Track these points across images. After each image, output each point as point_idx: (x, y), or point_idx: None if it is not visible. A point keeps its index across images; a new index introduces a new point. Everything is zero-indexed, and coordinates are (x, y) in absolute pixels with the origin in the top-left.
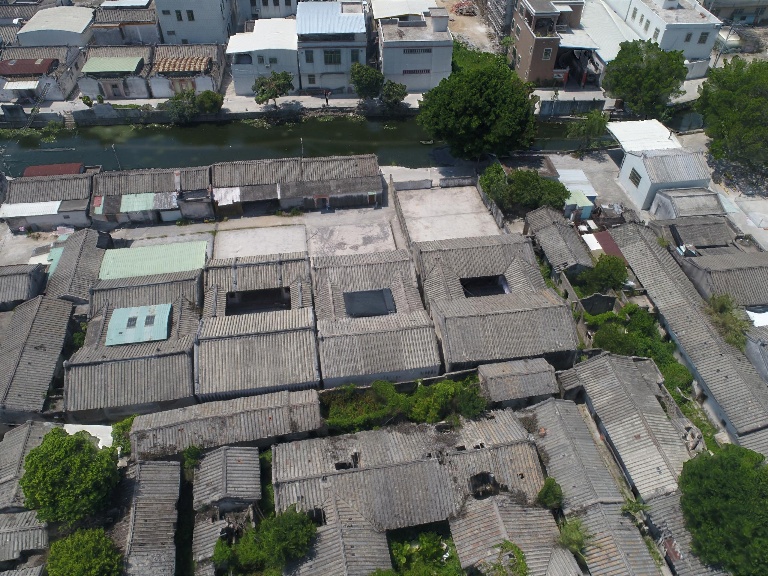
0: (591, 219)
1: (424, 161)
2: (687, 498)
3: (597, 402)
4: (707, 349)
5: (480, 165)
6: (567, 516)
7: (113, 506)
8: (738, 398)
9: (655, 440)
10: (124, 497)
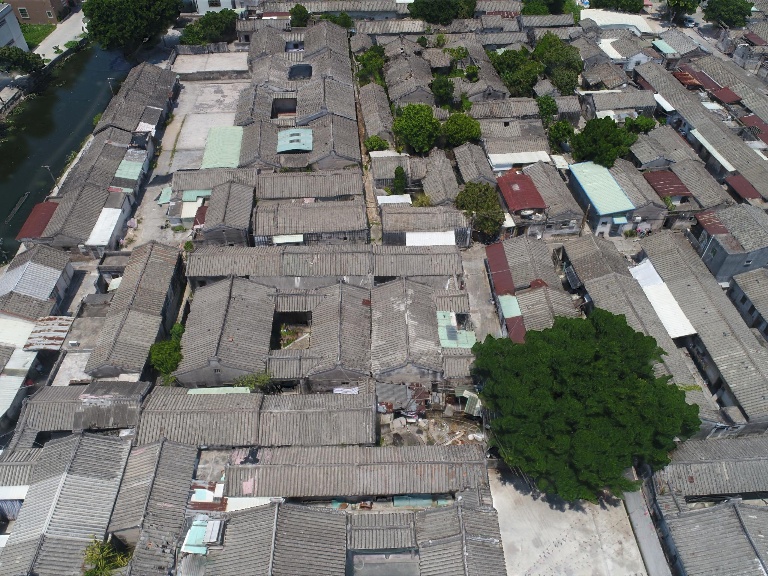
0: (248, 17)
1: (126, 74)
2: (431, 13)
3: (378, 31)
4: (356, 5)
5: (157, 48)
6: (429, 46)
7: None
8: (382, 5)
9: (402, 20)
10: None
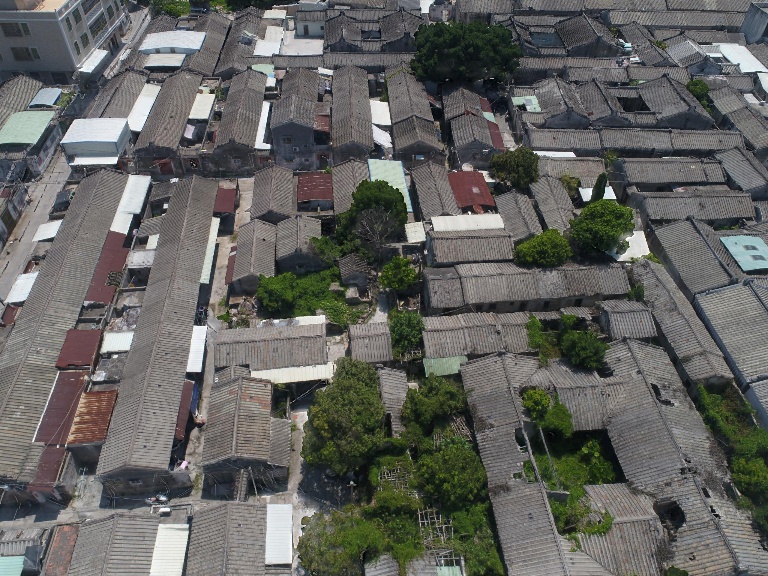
0: None
1: None
2: None
3: None
4: None
5: None
6: None
7: (589, 260)
8: None
9: None
10: (596, 264)
